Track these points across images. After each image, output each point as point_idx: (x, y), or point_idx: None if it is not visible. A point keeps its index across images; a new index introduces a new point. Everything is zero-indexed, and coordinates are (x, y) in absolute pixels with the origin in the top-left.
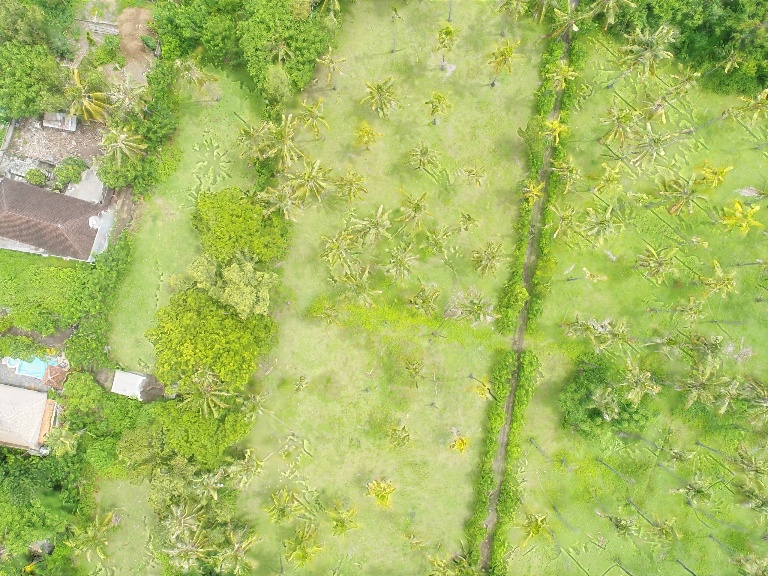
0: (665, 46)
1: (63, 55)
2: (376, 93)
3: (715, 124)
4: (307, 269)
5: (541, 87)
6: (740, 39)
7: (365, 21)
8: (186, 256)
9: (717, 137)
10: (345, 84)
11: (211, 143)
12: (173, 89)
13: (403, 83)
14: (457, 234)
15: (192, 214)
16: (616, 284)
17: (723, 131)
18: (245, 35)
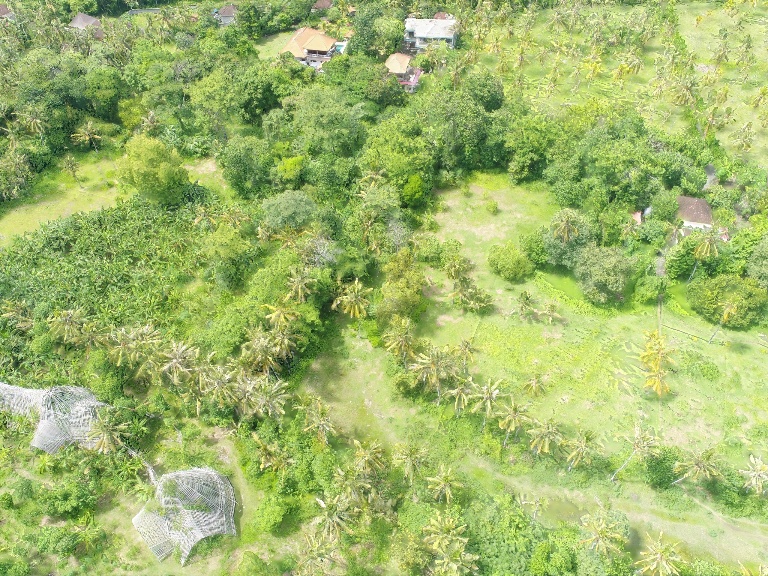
0: None
1: None
2: None
3: None
4: None
5: None
6: None
7: None
8: None
9: None
10: None
11: None
12: None
13: None
14: None
15: None
16: (633, 75)
17: None
18: None
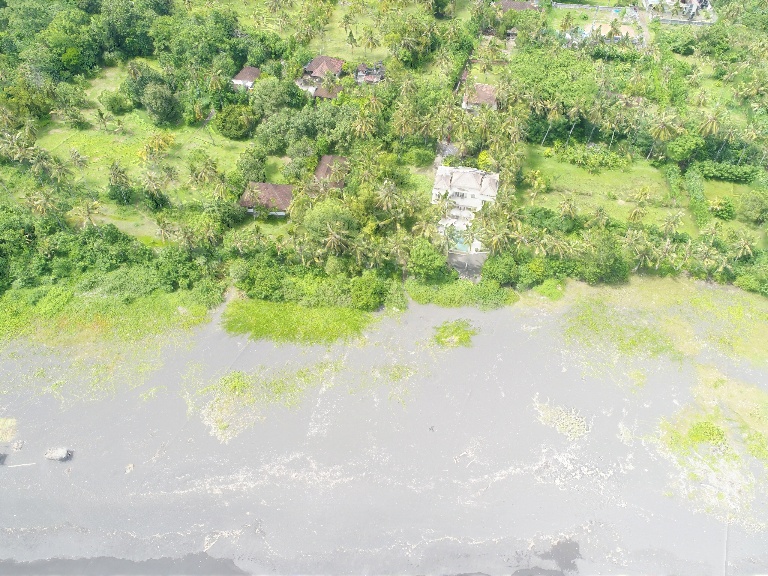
0: None
1: None
2: None
3: None
4: (410, 10)
5: None
6: None
7: None
8: None
9: None
10: None
11: None
12: None
13: None
14: None
15: None
16: (289, 5)
17: None
18: None
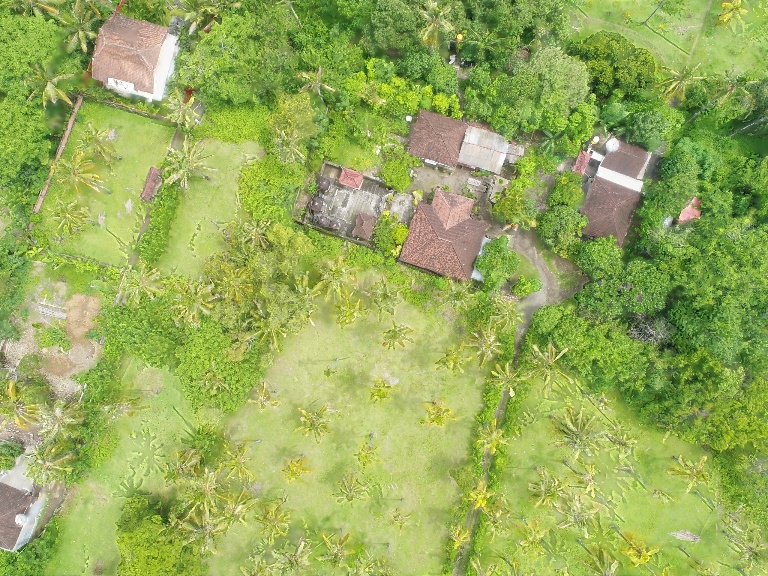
0: (609, 389)
1: (9, 337)
2: (310, 423)
3: (656, 463)
4: (232, 567)
5: (482, 412)
6: (678, 422)
7: (312, 326)
8: (113, 545)
9: (657, 477)
10: (286, 387)
11: (148, 433)
12: (115, 376)
13: (344, 392)
14: (385, 548)
15: (117, 523)
16: None
17: (663, 471)
18: (181, 365)
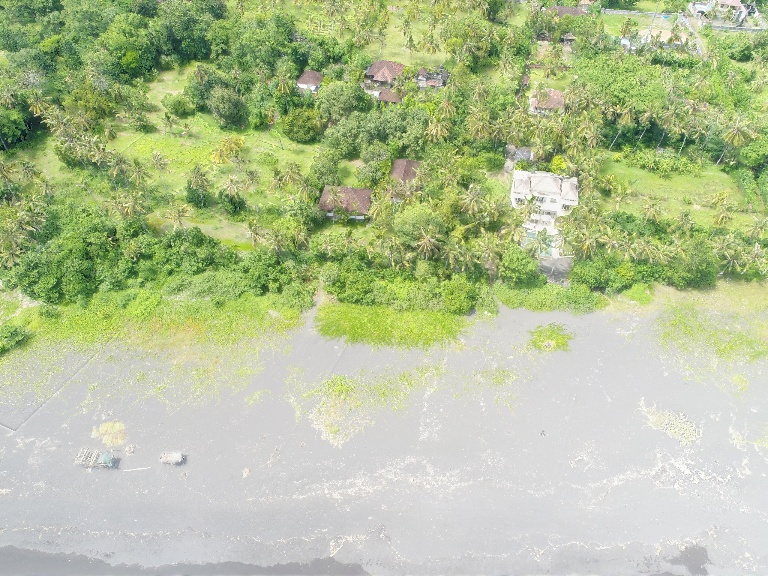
0: None
1: None
2: None
3: None
4: None
5: None
6: None
7: None
8: None
9: None
10: None
11: None
12: None
13: None
14: None
15: (505, 8)
16: None
17: None
18: None
